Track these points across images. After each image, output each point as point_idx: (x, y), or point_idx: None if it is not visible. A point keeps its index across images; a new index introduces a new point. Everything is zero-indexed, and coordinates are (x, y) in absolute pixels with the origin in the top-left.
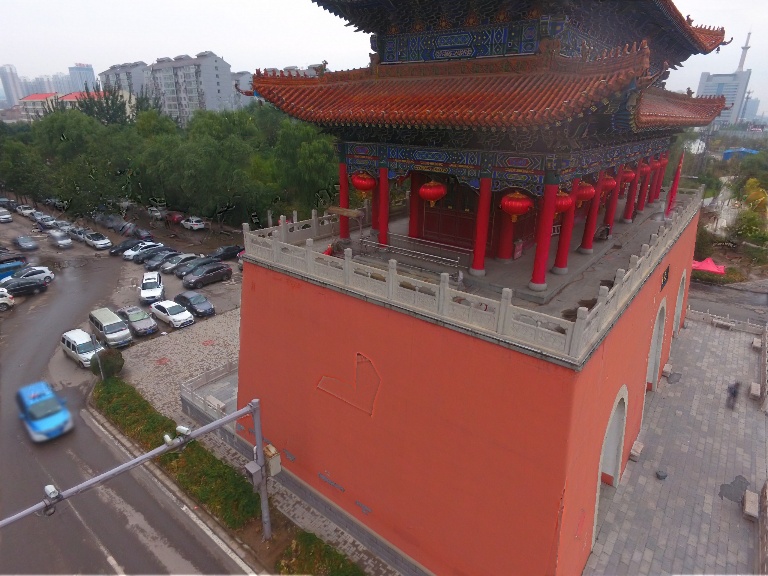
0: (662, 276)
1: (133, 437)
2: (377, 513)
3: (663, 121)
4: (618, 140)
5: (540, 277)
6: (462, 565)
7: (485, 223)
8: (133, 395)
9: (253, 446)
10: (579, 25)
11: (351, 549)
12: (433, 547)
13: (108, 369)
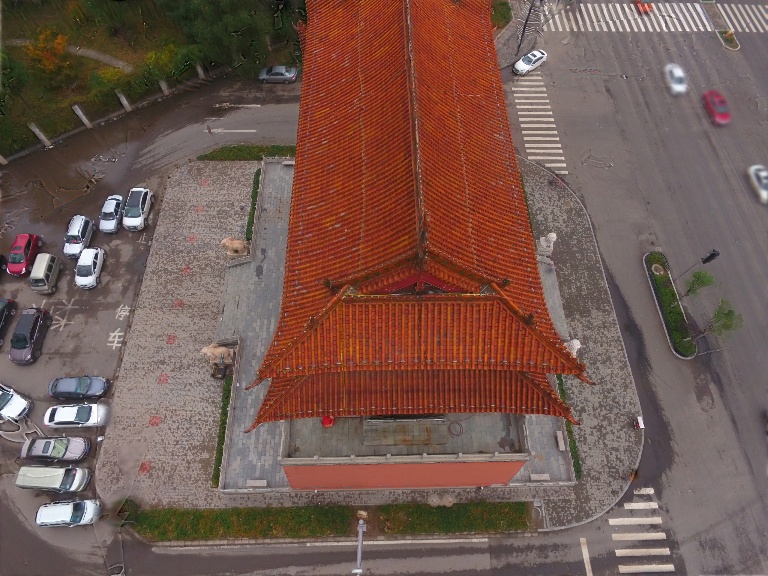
0: None
1: (222, 537)
2: (415, 484)
3: None
4: None
5: None
6: (466, 482)
7: None
8: (178, 514)
9: (313, 491)
10: None
11: (404, 496)
12: (450, 483)
13: (134, 517)
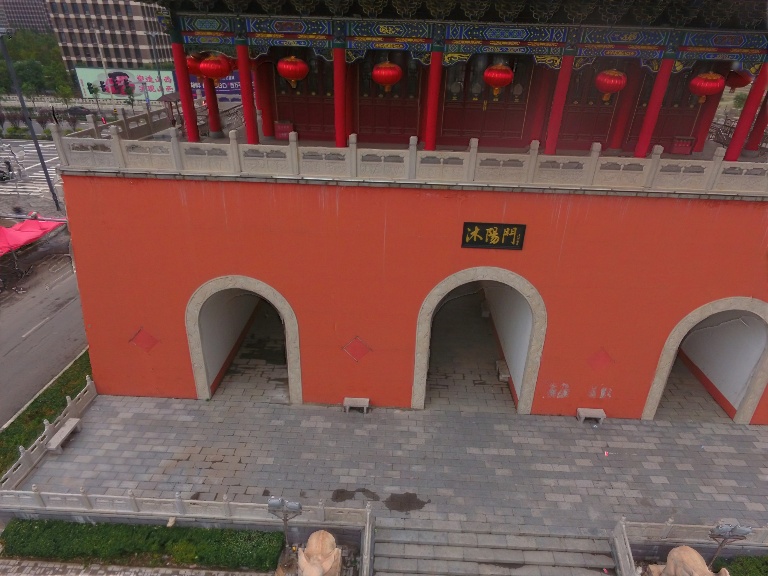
0: None
1: None
2: None
3: None
4: None
5: None
6: None
7: None
8: None
9: None
10: None
11: None
12: None
13: None
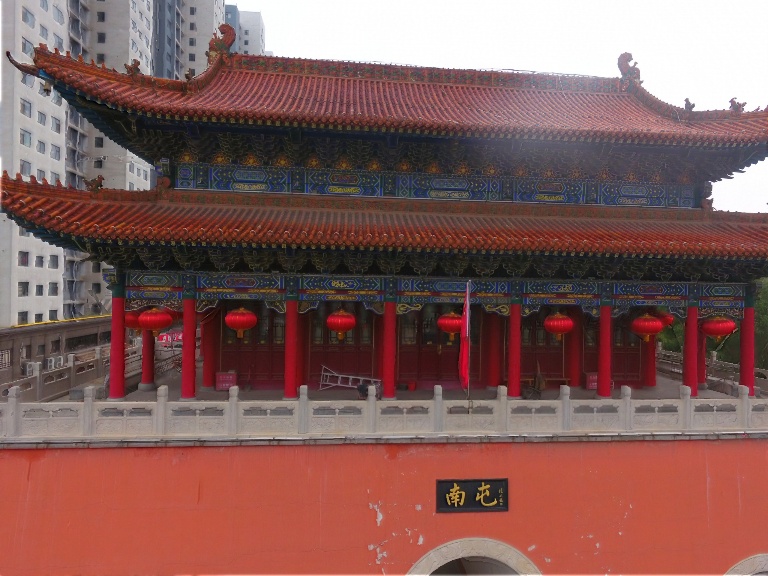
0: (438, 484)
1: None
2: None
3: (232, 236)
4: (323, 267)
5: (110, 390)
6: None
7: (144, 338)
8: None
9: None
10: (236, 161)
11: None
12: None
13: None
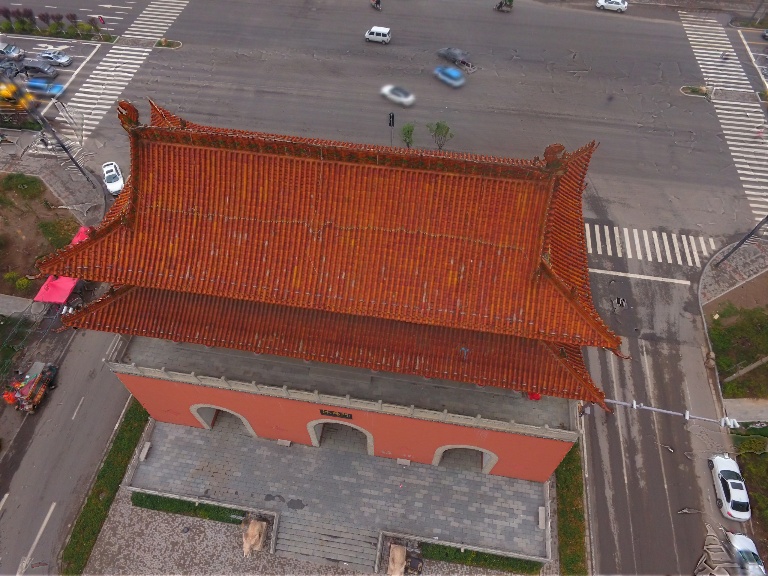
0: None
1: None
2: None
3: None
4: None
5: None
6: None
7: None
8: None
9: None
10: None
11: None
12: None
13: None
